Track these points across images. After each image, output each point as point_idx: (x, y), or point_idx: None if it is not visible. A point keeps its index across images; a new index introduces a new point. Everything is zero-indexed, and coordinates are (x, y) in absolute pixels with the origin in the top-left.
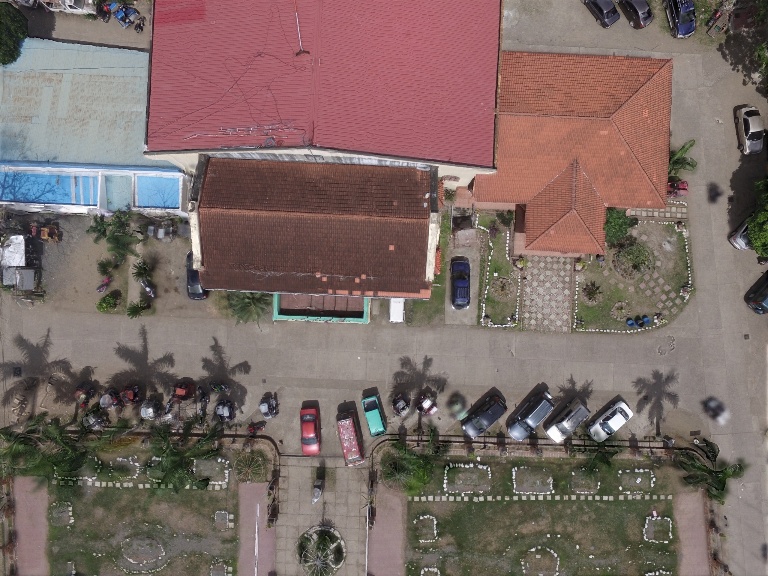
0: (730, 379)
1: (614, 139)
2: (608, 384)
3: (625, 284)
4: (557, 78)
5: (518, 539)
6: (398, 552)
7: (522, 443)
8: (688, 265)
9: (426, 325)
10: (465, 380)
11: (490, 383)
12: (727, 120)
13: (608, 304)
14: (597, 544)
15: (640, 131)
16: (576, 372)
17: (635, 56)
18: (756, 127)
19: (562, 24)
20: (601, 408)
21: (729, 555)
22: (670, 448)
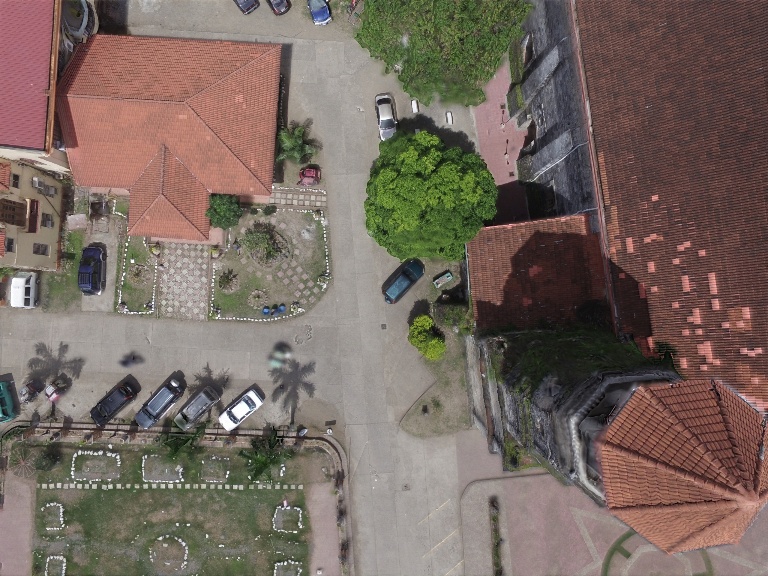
0: (366, 369)
1: (195, 124)
2: (244, 373)
3: (263, 272)
4: (151, 62)
5: (147, 528)
6: (26, 540)
7: (154, 431)
8: (326, 254)
9: (63, 311)
10: (101, 367)
11: (126, 370)
12: (368, 108)
13: (245, 292)
14: (227, 533)
15: (231, 116)
16: (212, 360)
17: (277, 43)
18: (385, 115)
19: (205, 9)
20: (236, 397)
21: (361, 546)
22: (301, 437)
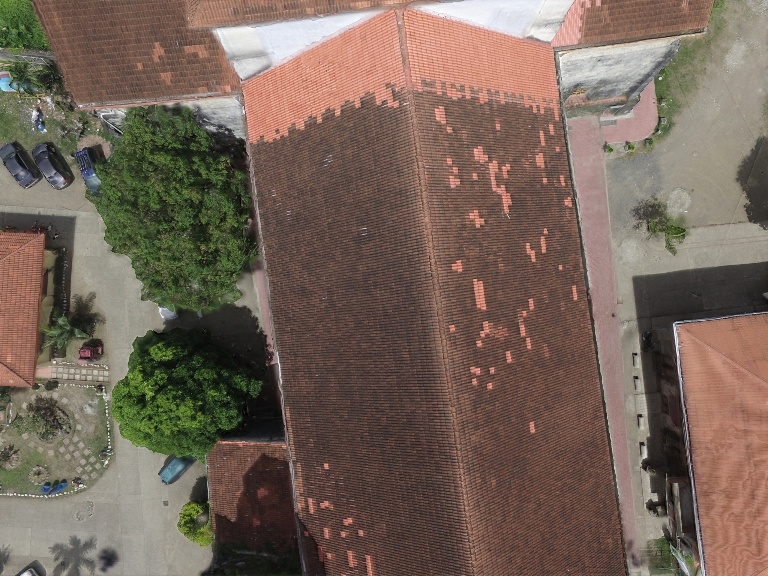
0: (148, 546)
1: None
2: (25, 549)
3: (45, 448)
4: None
5: None
6: None
7: None
8: (108, 430)
9: None
10: None
11: None
12: None
13: (27, 468)
14: None
15: None
16: None
17: (61, 215)
18: None
19: None
20: (17, 574)
21: None
22: None
